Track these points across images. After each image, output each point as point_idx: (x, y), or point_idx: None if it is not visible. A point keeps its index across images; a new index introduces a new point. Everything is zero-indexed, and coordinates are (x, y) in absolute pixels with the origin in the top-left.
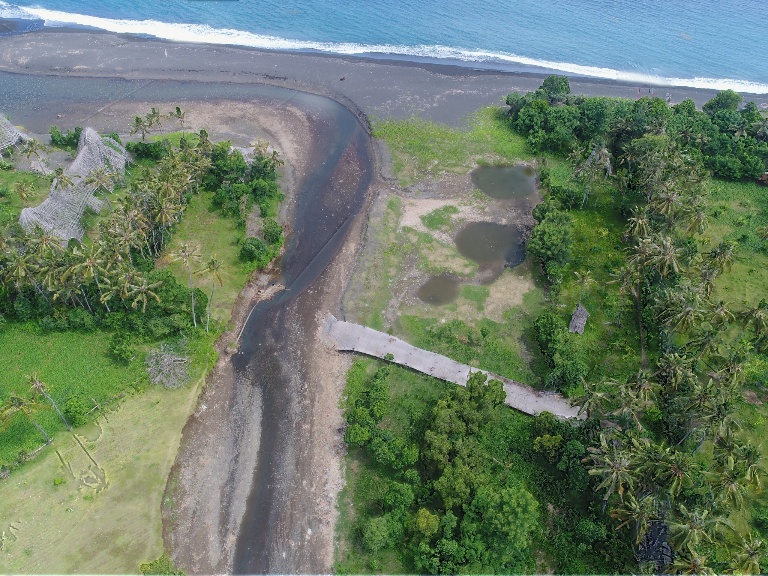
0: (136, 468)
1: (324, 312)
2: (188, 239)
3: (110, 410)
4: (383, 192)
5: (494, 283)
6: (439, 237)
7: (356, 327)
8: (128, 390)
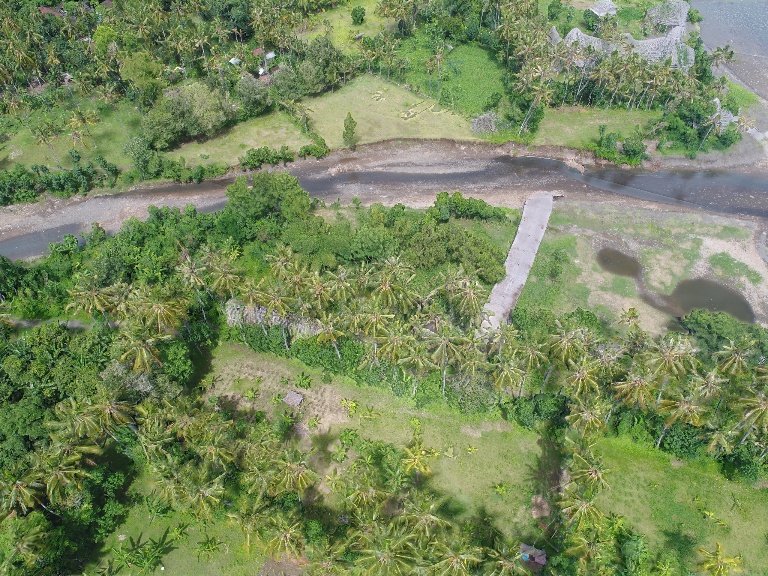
0: (417, 126)
1: (564, 194)
2: (610, 116)
3: (452, 112)
4: (749, 222)
5: (645, 303)
6: (699, 265)
7: (549, 206)
8: (467, 115)
